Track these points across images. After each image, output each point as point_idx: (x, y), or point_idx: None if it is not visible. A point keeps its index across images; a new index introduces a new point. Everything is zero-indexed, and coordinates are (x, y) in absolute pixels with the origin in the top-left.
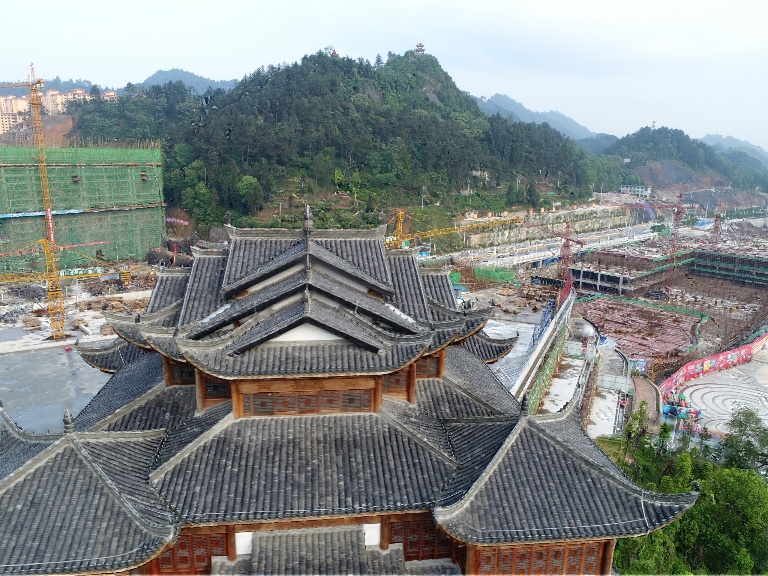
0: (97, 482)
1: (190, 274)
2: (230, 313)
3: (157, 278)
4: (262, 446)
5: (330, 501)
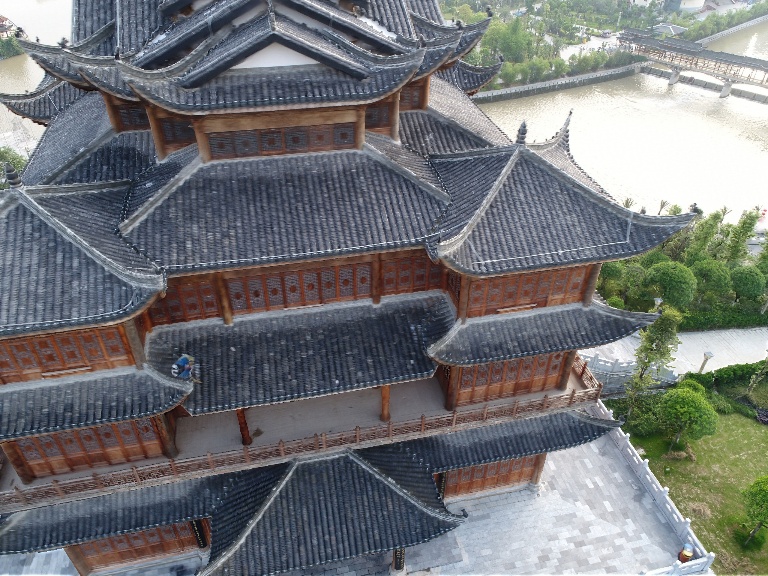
0: (539, 153)
1: (309, 5)
2: (407, 10)
3: (283, 32)
4: (447, 111)
5: (474, 109)
